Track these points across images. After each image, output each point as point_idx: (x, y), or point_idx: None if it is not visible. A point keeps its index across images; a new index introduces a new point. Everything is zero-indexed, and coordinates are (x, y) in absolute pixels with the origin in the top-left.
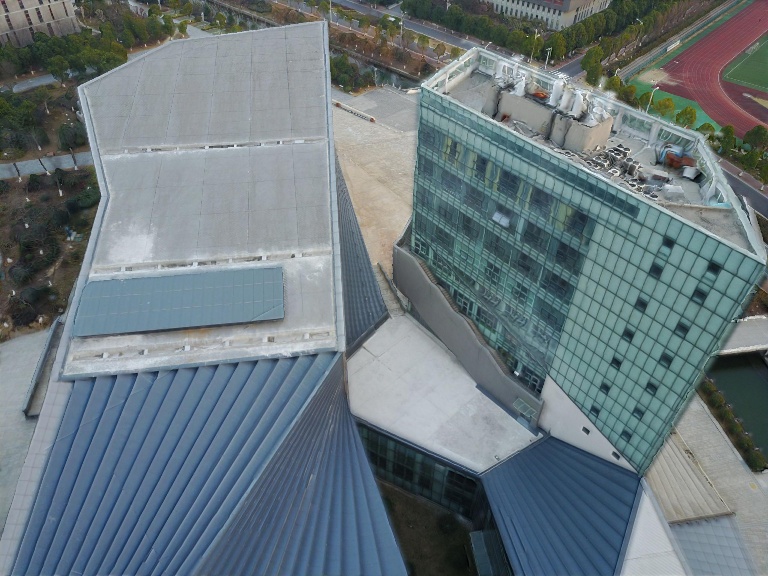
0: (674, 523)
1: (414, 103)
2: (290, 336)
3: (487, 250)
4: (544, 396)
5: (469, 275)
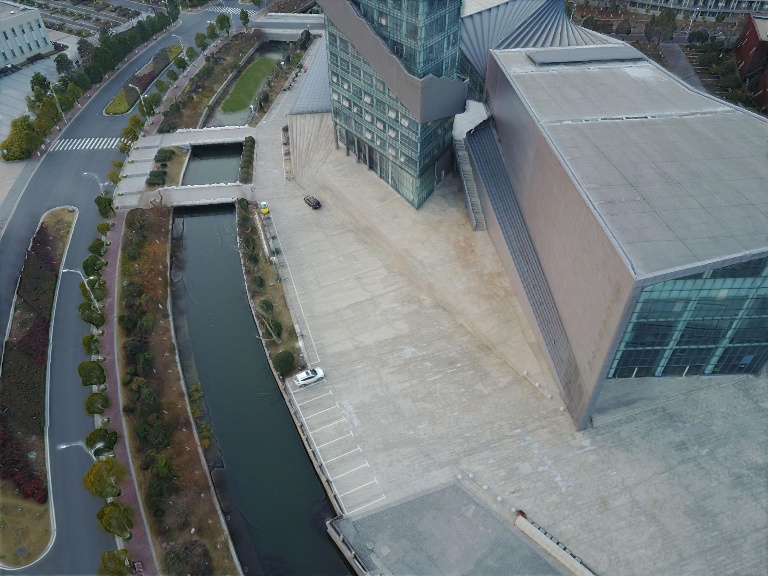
0: (319, 112)
1: None
2: None
3: None
4: None
5: None
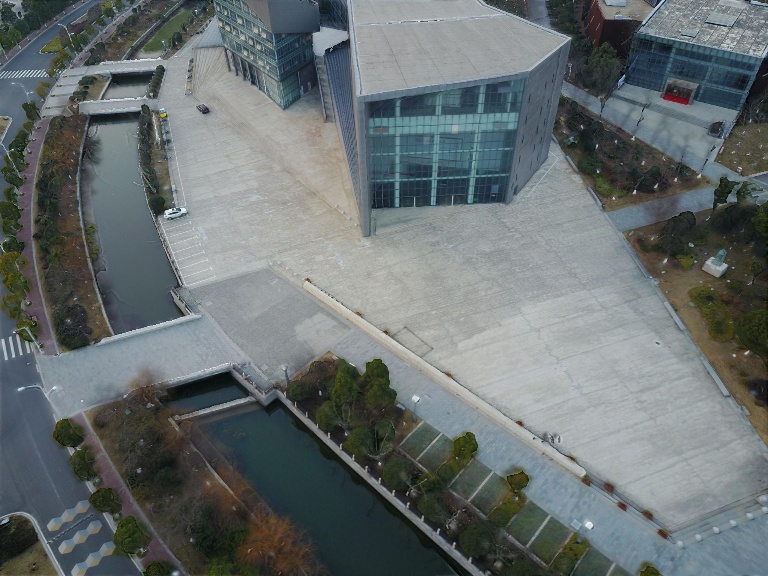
0: (220, 46)
1: (232, 337)
2: None
3: None
4: None
5: None
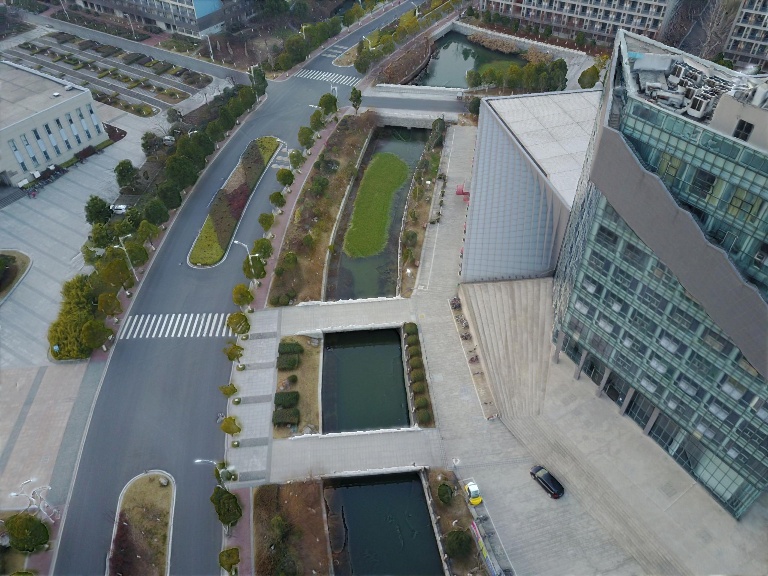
0: (505, 279)
1: None
2: None
3: None
4: None
5: None
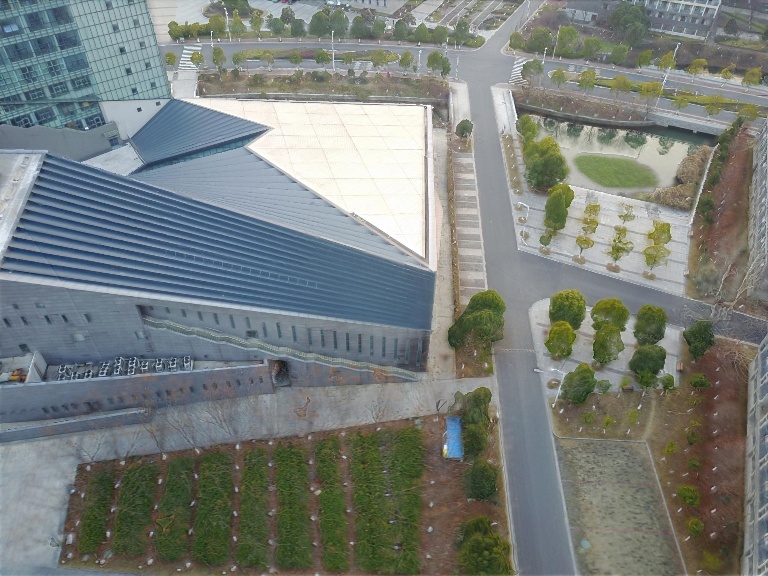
0: None
1: None
2: (18, 173)
3: (14, 62)
4: (110, 119)
5: (15, 94)
